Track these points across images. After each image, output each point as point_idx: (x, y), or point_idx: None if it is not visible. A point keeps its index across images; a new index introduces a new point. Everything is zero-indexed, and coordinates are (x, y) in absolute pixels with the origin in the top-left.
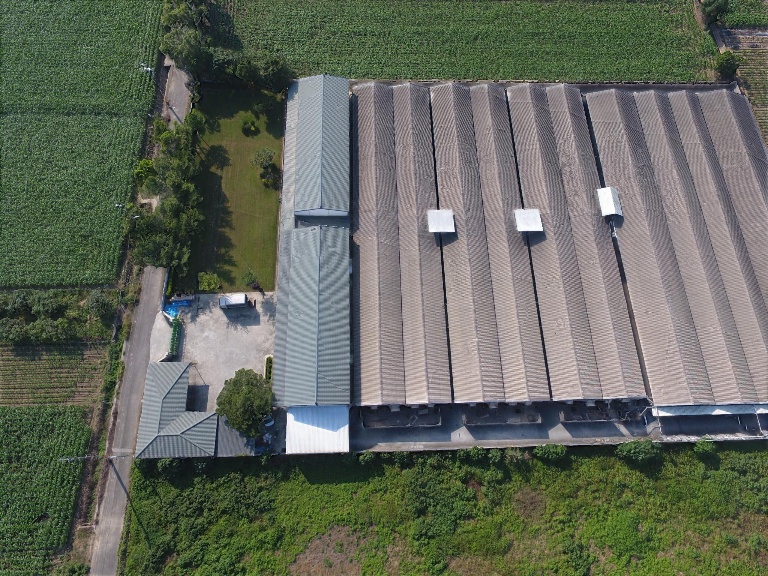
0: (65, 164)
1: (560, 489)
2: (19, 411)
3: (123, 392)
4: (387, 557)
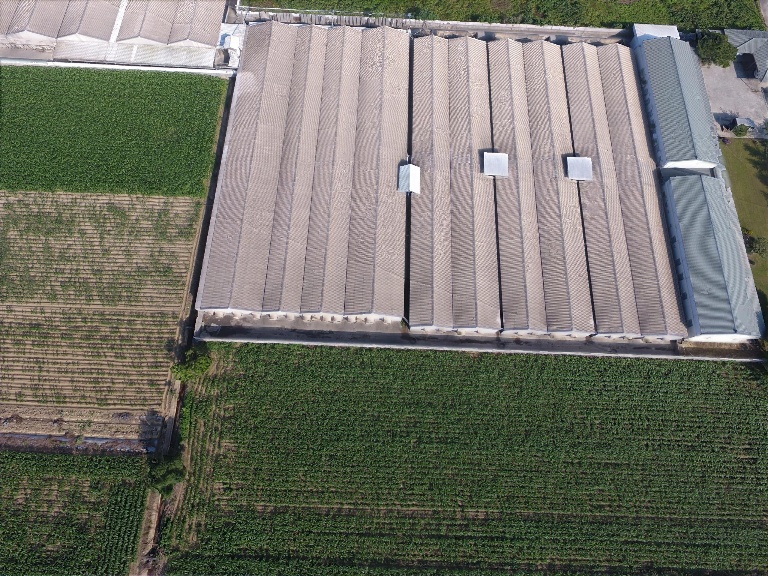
0: None
1: (481, 7)
2: None
3: None
4: None
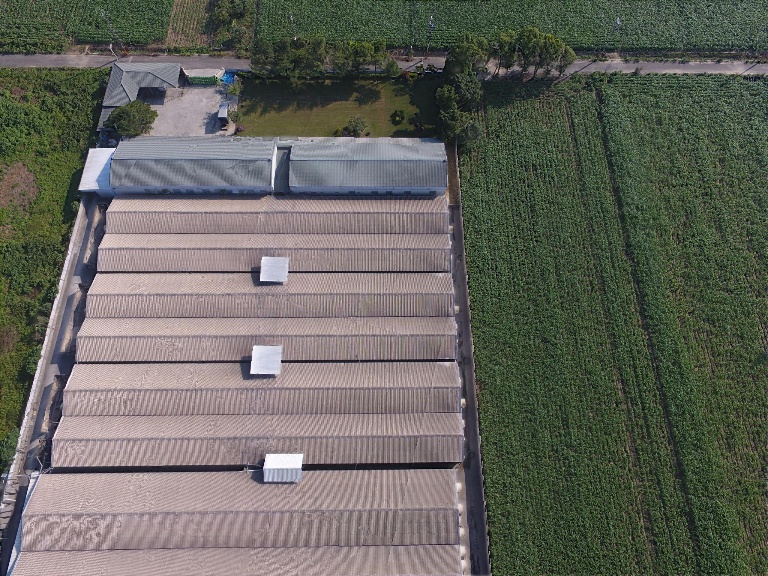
0: (362, 2)
1: (5, 368)
2: (168, 6)
3: (171, 58)
4: (4, 225)
